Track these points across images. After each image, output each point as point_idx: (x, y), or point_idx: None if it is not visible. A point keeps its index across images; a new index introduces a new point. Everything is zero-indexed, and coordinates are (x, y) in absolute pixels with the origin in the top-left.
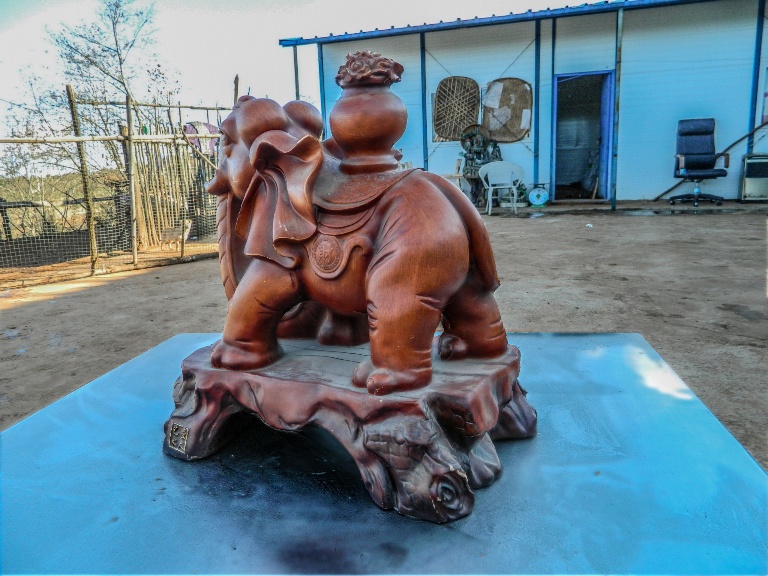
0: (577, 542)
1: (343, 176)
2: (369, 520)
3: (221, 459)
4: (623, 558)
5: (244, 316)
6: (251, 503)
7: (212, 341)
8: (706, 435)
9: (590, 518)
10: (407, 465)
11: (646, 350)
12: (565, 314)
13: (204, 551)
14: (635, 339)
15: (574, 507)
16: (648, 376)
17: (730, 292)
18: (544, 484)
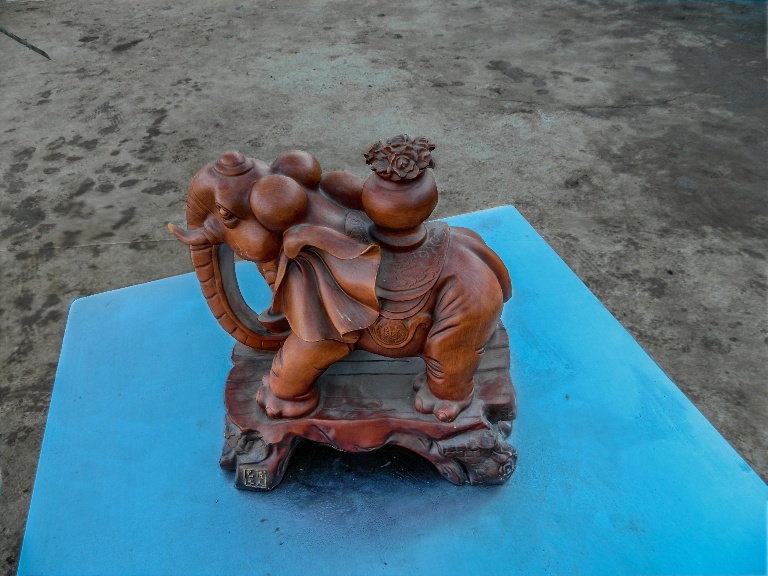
0: (587, 467)
1: (387, 255)
2: (456, 499)
3: (295, 478)
4: (616, 471)
5: (302, 380)
6: (362, 517)
7: (130, 308)
8: (609, 331)
9: (584, 443)
10: (479, 461)
11: (528, 231)
12: (362, 97)
13: (367, 575)
14: (514, 216)
15: (570, 436)
16: (546, 268)
17: (492, 44)
18: (542, 420)
